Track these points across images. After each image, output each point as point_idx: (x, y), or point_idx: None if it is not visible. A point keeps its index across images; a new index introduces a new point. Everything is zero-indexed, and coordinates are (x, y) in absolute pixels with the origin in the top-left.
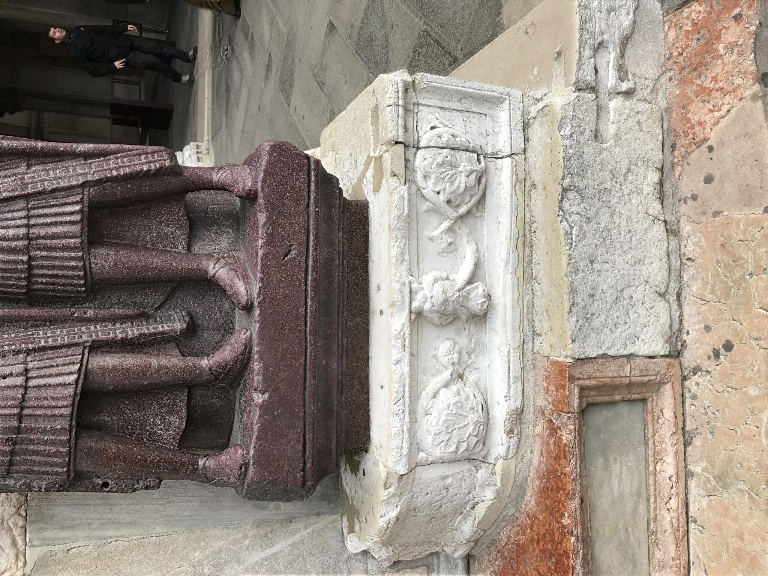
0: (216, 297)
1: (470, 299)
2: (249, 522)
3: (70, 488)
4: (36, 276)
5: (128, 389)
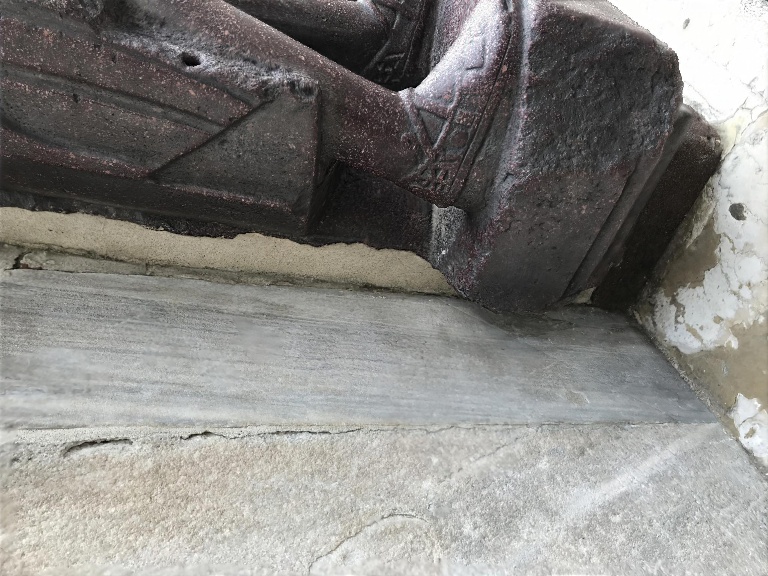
0: None
1: None
2: (528, 422)
3: (102, 30)
4: None
5: None
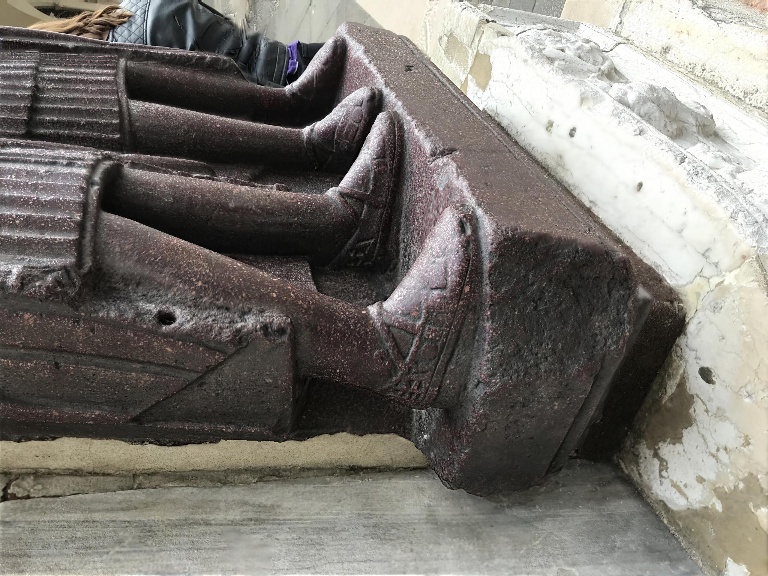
0: (321, 190)
1: None
2: None
3: (81, 306)
4: (43, 114)
5: (200, 214)
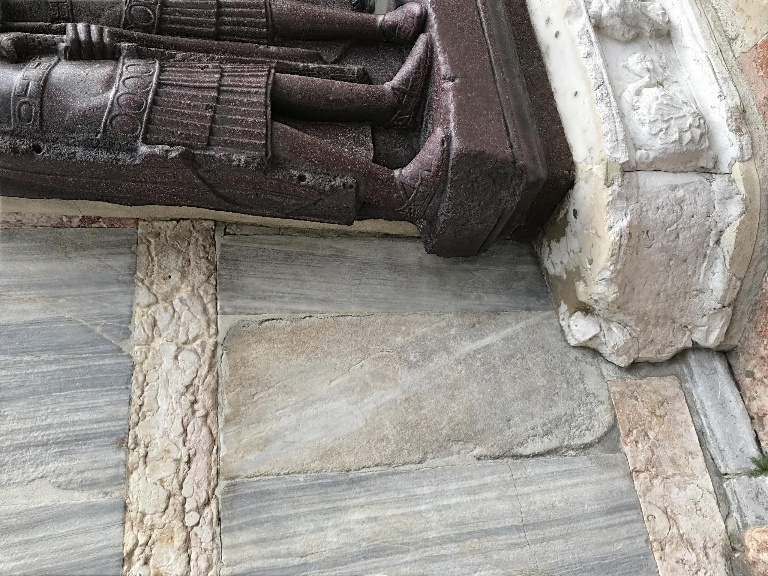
0: (386, 59)
1: (648, 11)
2: (452, 311)
3: (268, 173)
4: (223, 15)
5: (315, 104)
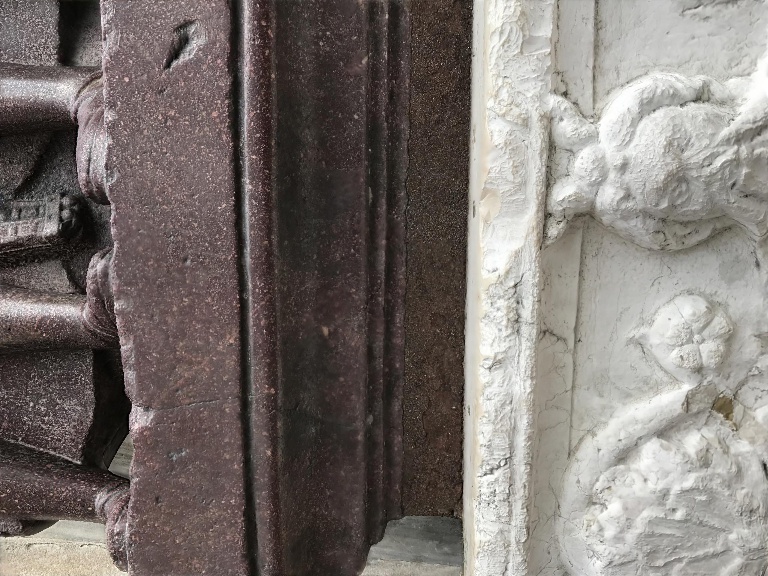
0: None
1: None
2: None
3: None
4: None
5: None
